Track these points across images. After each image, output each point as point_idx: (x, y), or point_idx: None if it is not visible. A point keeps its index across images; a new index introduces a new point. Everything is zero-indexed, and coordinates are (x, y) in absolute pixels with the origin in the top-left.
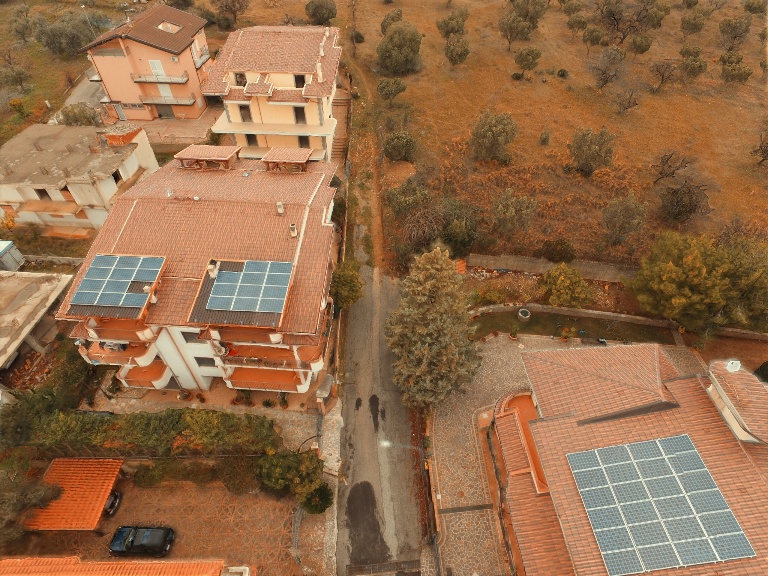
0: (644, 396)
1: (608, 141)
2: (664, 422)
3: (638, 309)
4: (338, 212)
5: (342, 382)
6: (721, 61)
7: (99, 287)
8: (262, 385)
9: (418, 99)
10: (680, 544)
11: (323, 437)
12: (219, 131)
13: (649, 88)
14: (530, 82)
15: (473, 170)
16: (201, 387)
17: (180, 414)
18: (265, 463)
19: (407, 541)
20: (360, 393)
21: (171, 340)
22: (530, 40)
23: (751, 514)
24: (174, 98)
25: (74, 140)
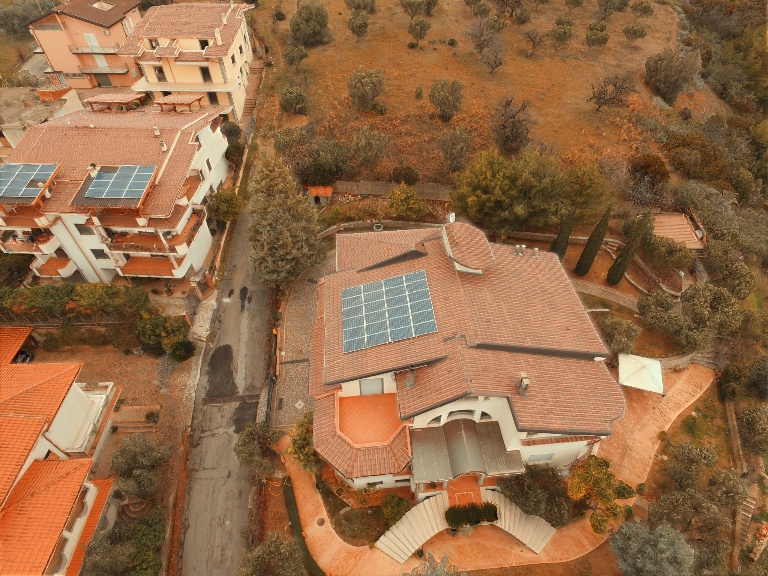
0: (403, 249)
1: (458, 89)
2: (414, 265)
3: (471, 222)
4: (233, 152)
5: (221, 278)
6: (589, 29)
7: (5, 184)
8: (145, 271)
9: (322, 65)
10: (394, 330)
11: (198, 315)
12: (137, 89)
13: (525, 53)
14: (423, 50)
15: (355, 119)
16: (103, 281)
17: (74, 287)
18: (140, 323)
19: (253, 383)
20: (234, 286)
21: (68, 232)
22: (433, 16)
23: (445, 310)
24: (109, 67)
25: (12, 98)
